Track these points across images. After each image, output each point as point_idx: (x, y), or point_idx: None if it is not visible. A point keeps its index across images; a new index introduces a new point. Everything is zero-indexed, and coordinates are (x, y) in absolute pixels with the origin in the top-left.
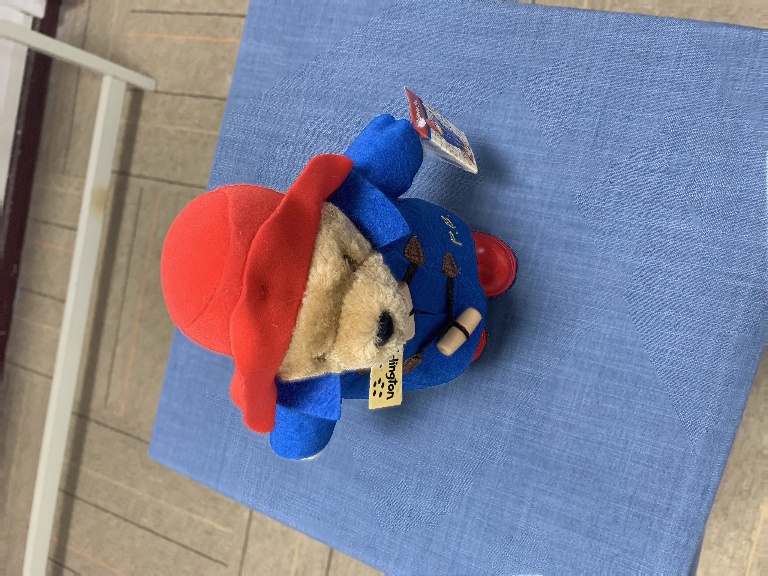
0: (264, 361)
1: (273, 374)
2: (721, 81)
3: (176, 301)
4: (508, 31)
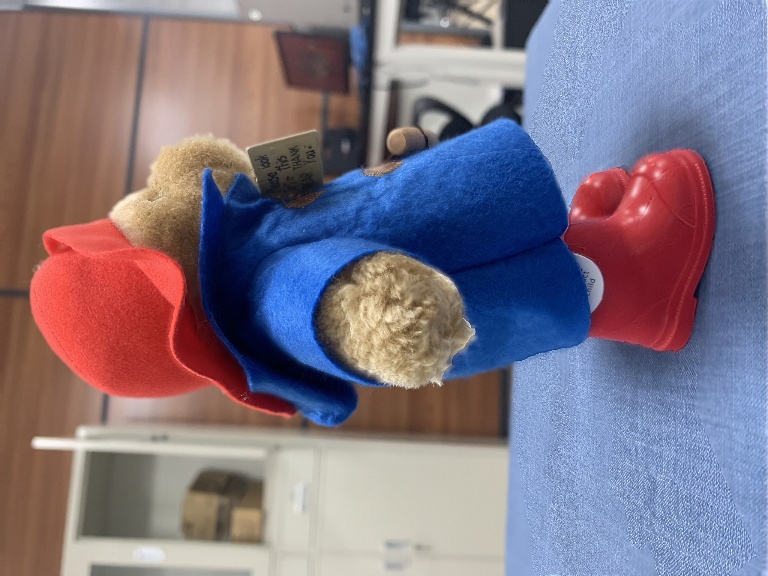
0: None
1: None
2: None
3: None
4: None
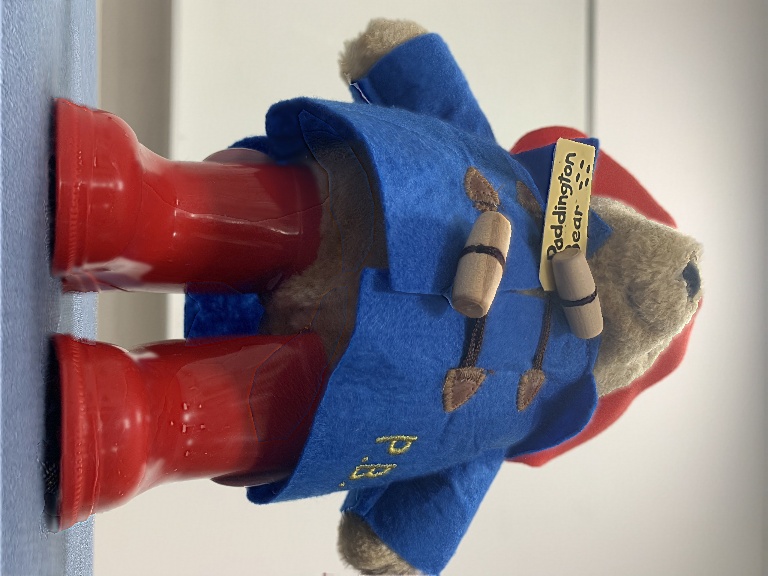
0: None
1: None
2: None
3: None
4: None
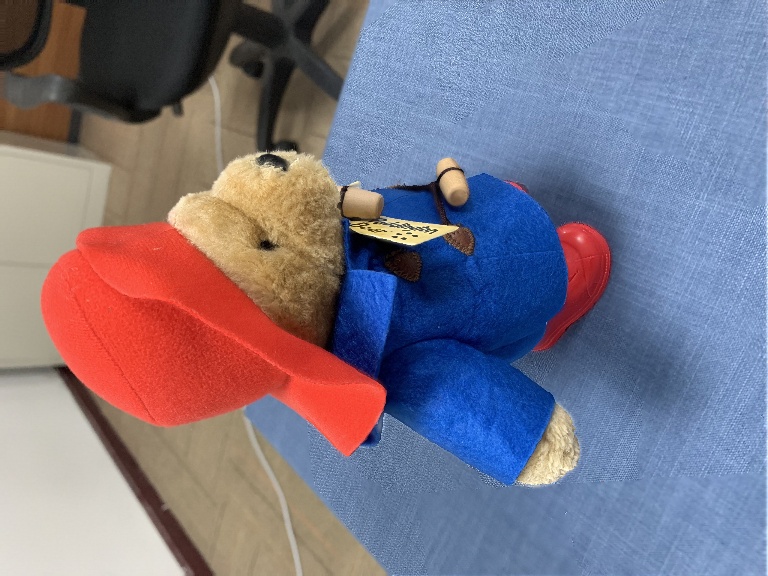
0: (187, 279)
1: (250, 307)
2: (400, 1)
3: (75, 351)
4: None
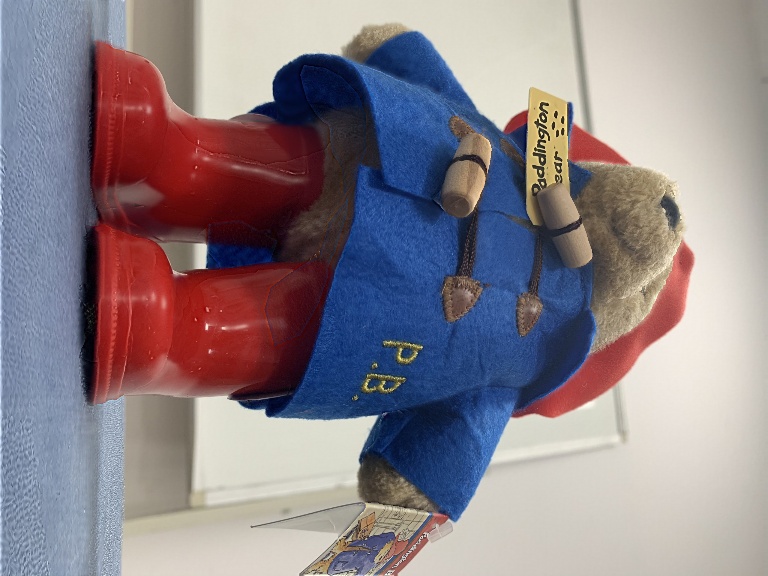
0: None
1: None
2: None
3: None
4: None
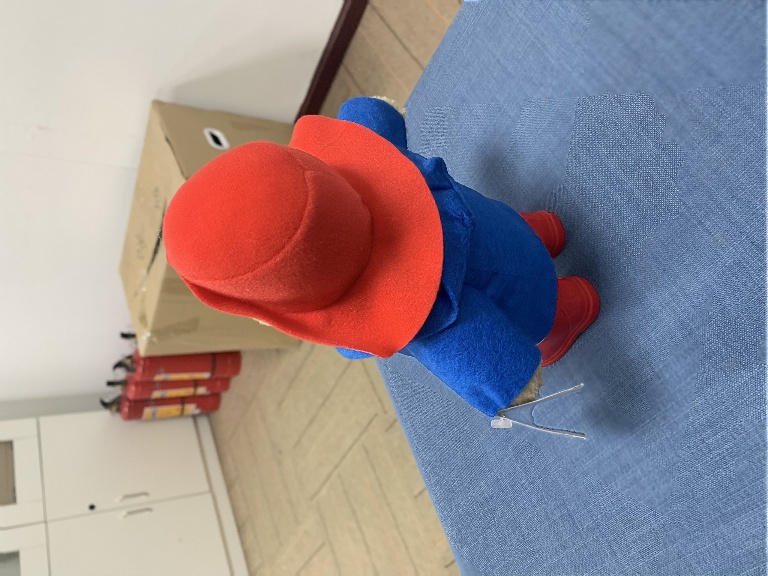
0: None
1: None
2: None
3: None
4: (732, 573)
